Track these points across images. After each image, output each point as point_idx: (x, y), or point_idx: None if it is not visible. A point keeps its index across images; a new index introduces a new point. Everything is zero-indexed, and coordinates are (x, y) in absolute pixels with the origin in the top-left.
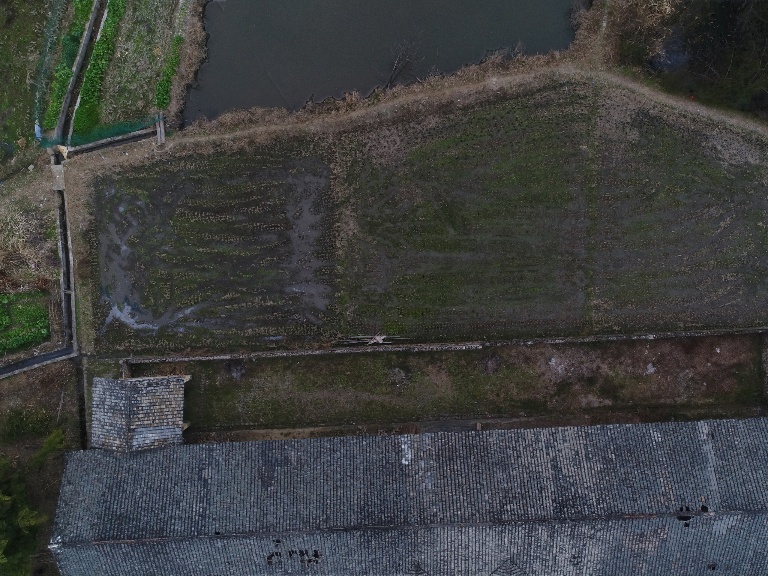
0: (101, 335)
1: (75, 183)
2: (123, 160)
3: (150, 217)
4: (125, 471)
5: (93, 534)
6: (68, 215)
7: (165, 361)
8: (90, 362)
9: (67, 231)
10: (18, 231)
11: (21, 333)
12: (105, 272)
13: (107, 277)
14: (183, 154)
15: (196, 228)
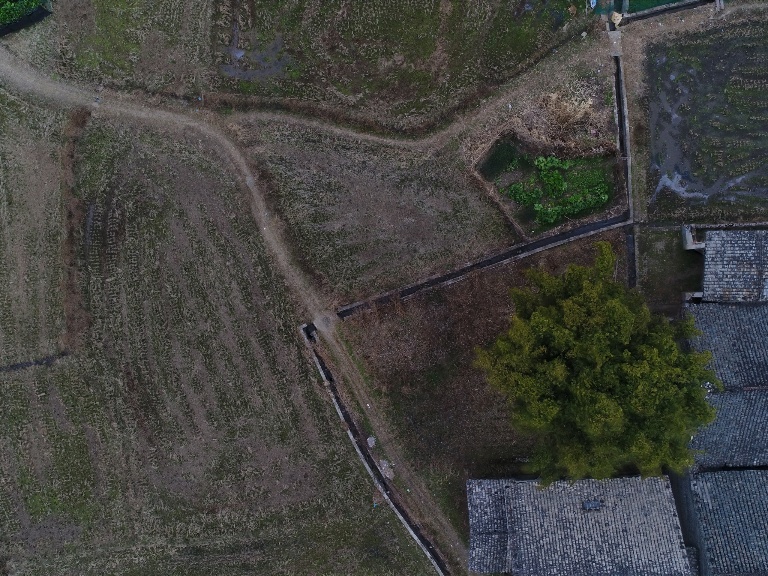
0: (654, 203)
1: (633, 49)
2: (679, 27)
3: (701, 85)
4: (746, 323)
5: (740, 380)
6: (626, 81)
7: (732, 226)
8: (643, 230)
9: (620, 98)
10: (580, 96)
11: (579, 199)
12: (656, 140)
13: (657, 145)
14: (738, 21)
15: (749, 96)
